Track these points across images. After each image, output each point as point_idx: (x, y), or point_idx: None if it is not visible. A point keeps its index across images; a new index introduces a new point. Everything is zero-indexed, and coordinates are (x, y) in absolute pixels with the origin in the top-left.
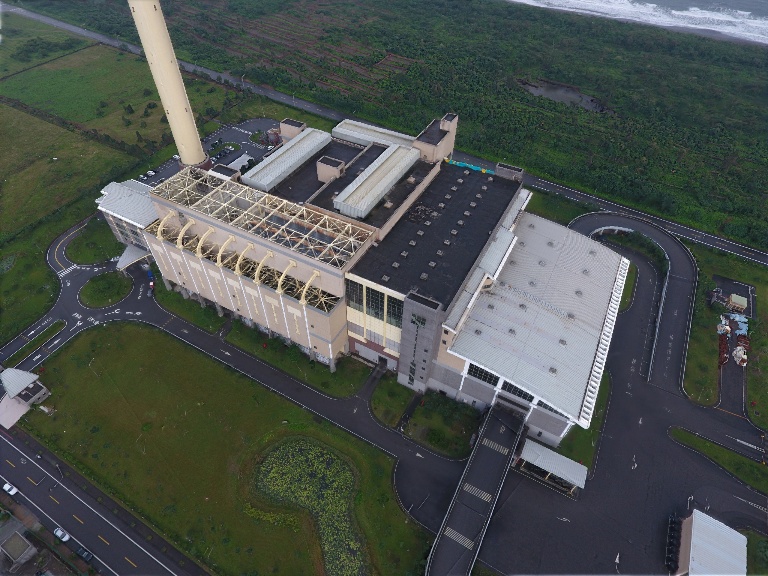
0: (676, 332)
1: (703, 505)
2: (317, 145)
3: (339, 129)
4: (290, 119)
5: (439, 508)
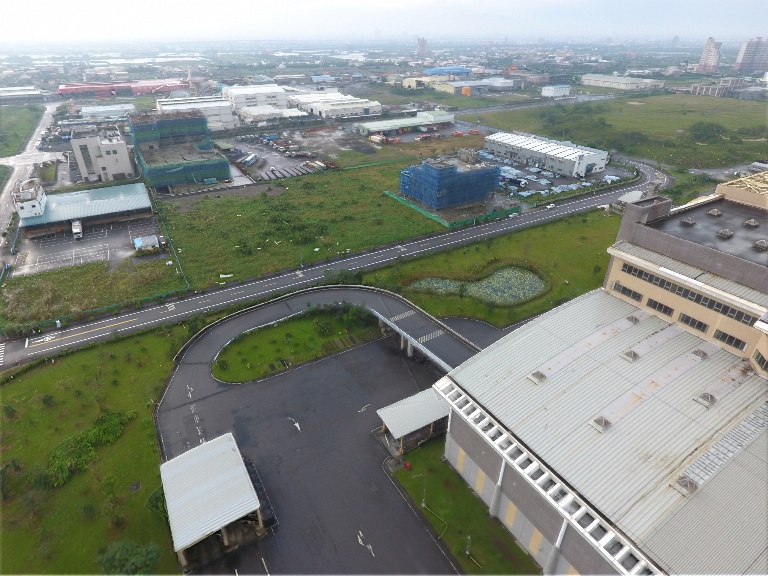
0: None
1: None
2: None
3: None
4: None
5: None
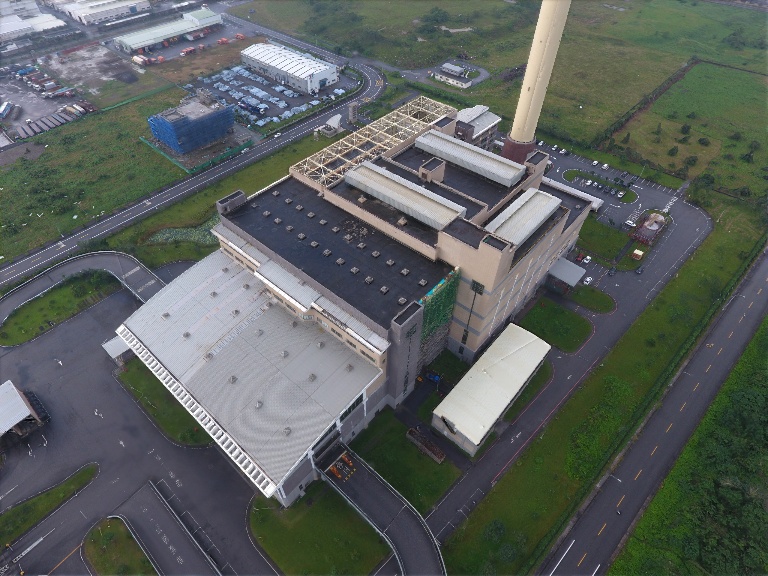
0: (182, 573)
1: (34, 450)
2: (486, 170)
3: (532, 191)
4: (546, 156)
5: (161, 278)
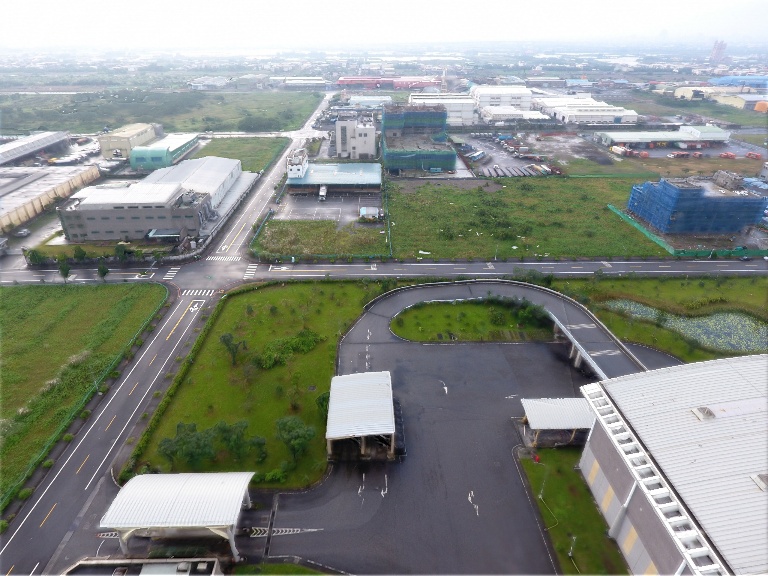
0: None
1: (367, 490)
2: None
3: None
4: None
5: None
